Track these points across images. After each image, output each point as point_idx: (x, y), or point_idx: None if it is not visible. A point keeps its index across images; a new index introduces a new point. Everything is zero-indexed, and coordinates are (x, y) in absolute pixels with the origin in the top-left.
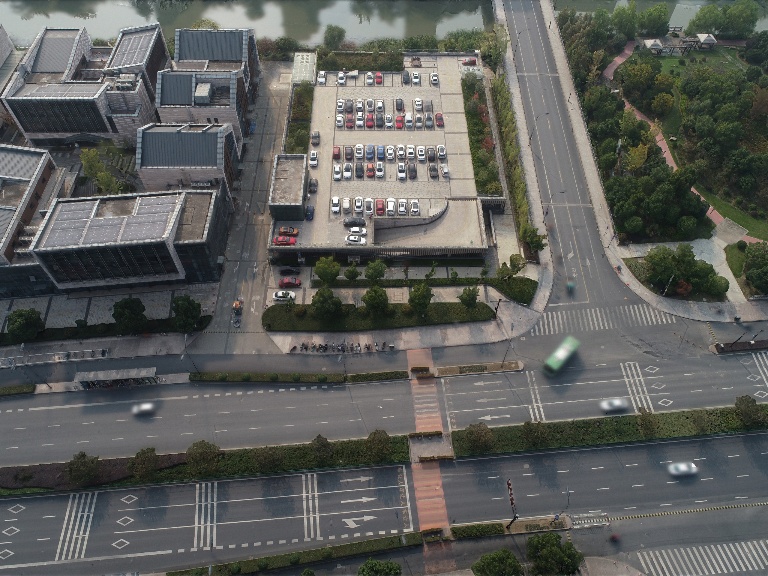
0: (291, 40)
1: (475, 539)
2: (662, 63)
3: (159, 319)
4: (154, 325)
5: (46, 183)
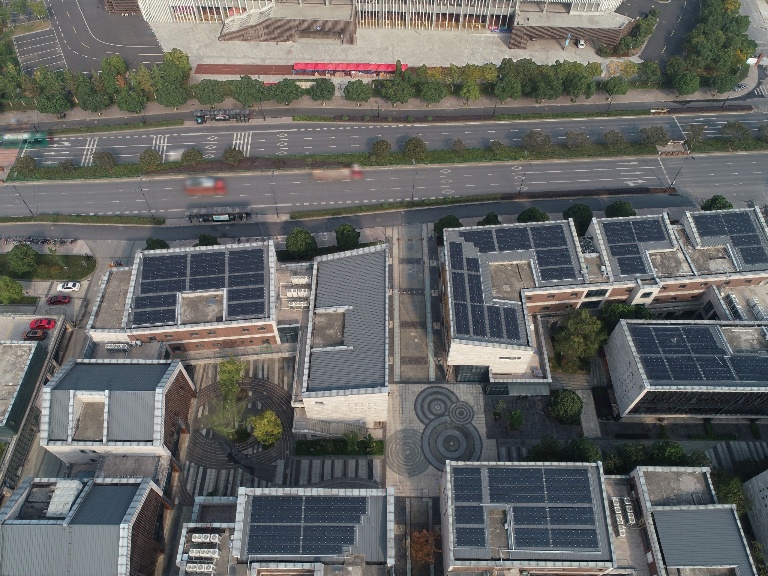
0: None
1: None
2: None
3: None
4: None
5: None
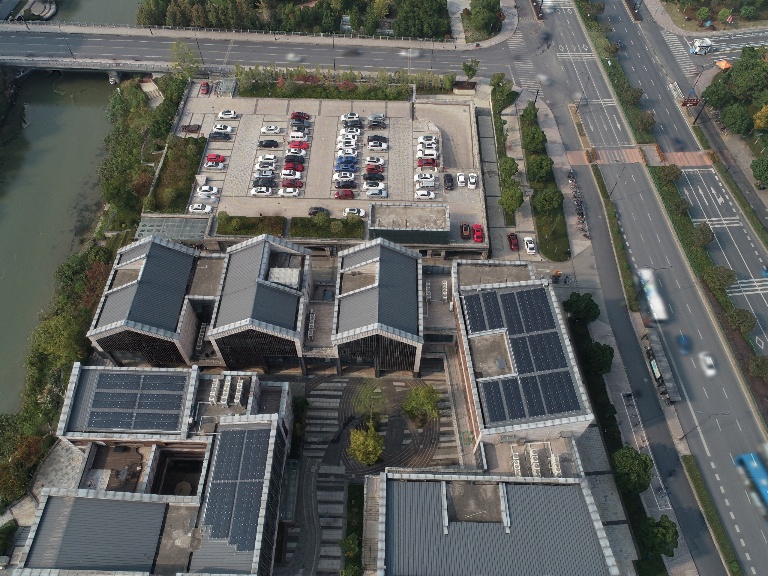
0: (74, 260)
1: None
2: None
3: None
4: None
5: None
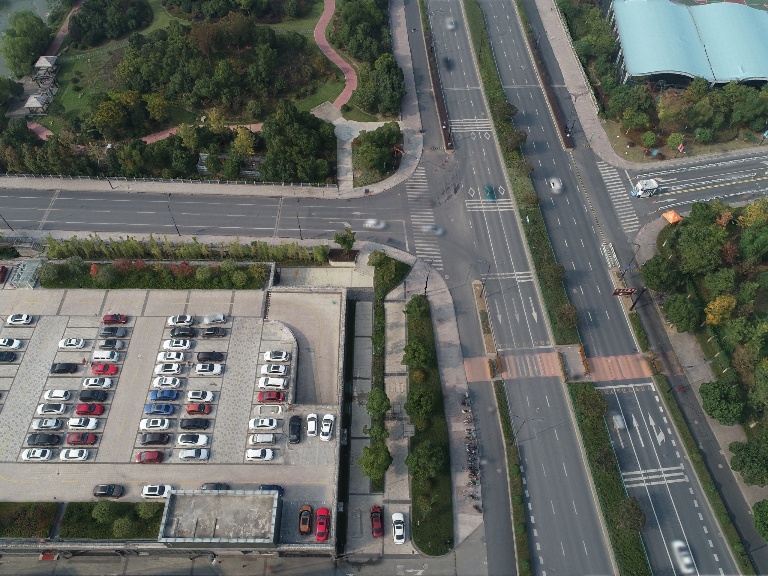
0: None
1: (646, 335)
2: (69, 104)
3: None
4: None
5: None
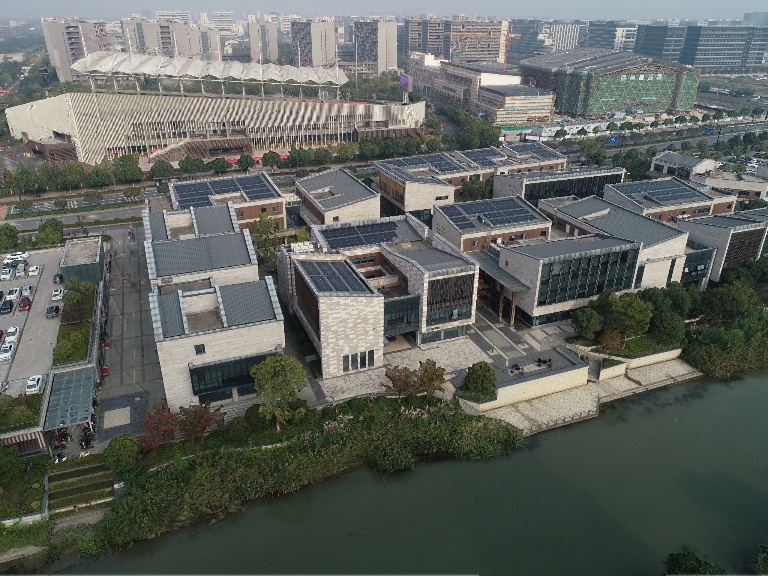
0: (117, 504)
1: None
2: None
3: None
4: None
5: None
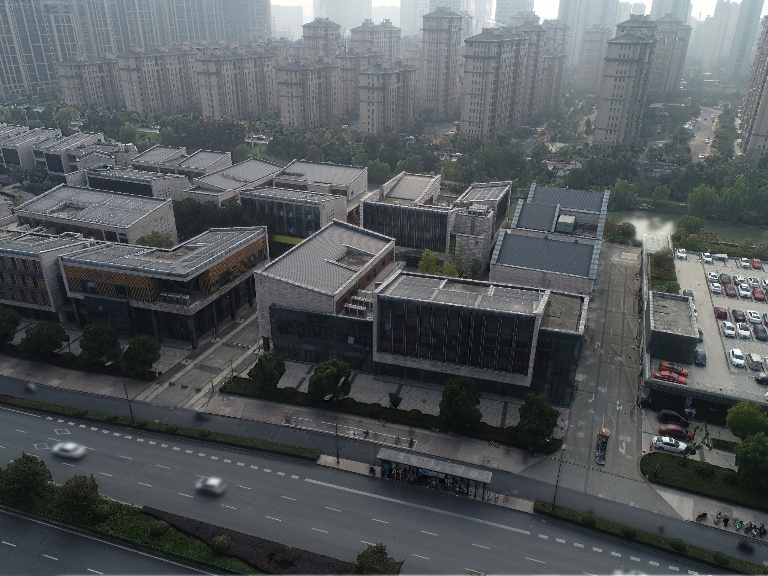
0: None
1: None
2: None
3: (489, 425)
4: (484, 428)
5: (383, 268)
